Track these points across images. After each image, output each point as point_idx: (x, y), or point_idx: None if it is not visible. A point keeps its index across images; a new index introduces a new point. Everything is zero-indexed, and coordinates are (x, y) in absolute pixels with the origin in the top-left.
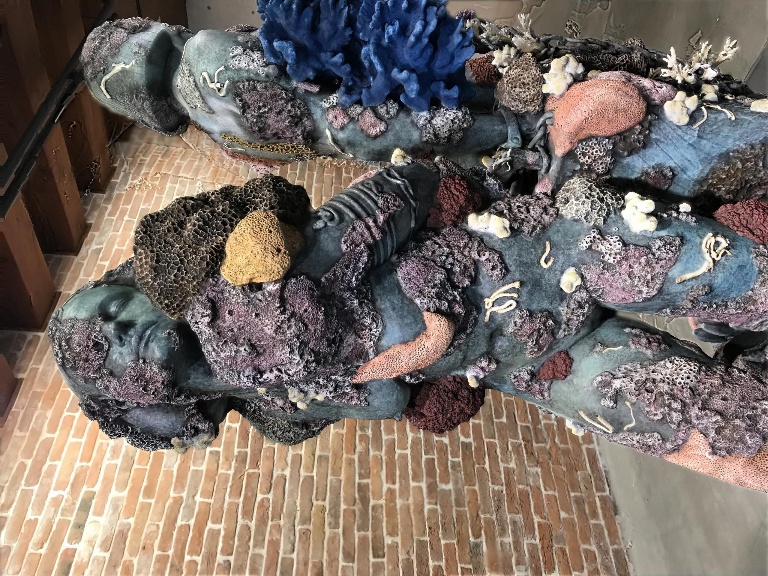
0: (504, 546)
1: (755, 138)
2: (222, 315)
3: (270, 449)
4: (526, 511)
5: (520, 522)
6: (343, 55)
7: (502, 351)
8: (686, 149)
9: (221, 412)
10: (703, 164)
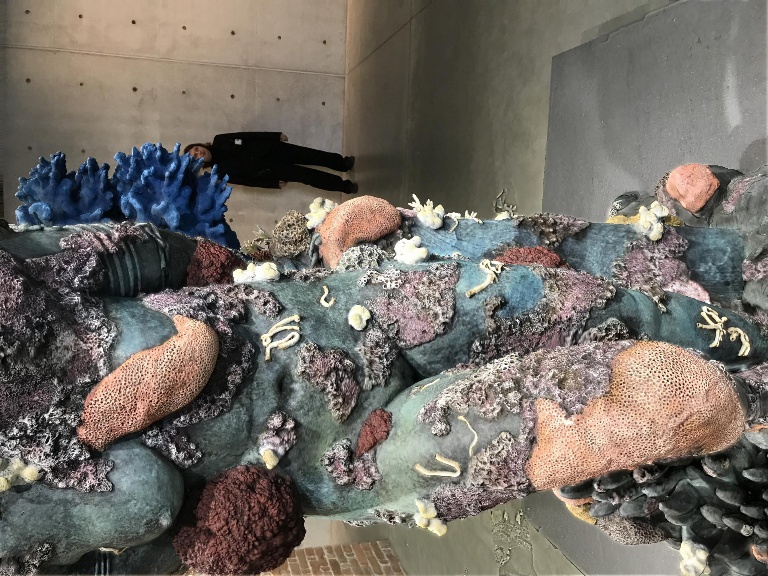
0: None
1: (508, 238)
2: None
3: None
4: None
5: None
6: (102, 209)
7: (298, 405)
8: (452, 251)
9: None
10: None
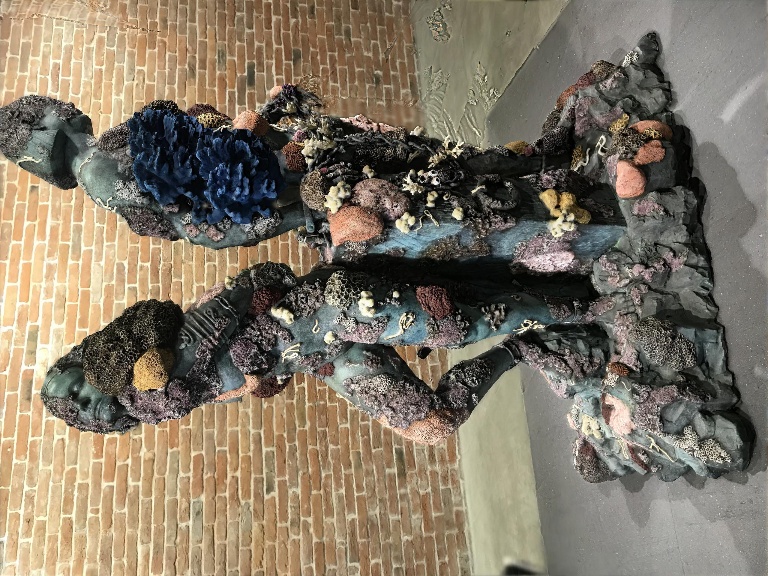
0: None
1: (452, 233)
2: (136, 400)
3: (178, 283)
4: None
5: None
6: (192, 193)
7: (294, 370)
8: (411, 240)
9: None
10: (423, 245)
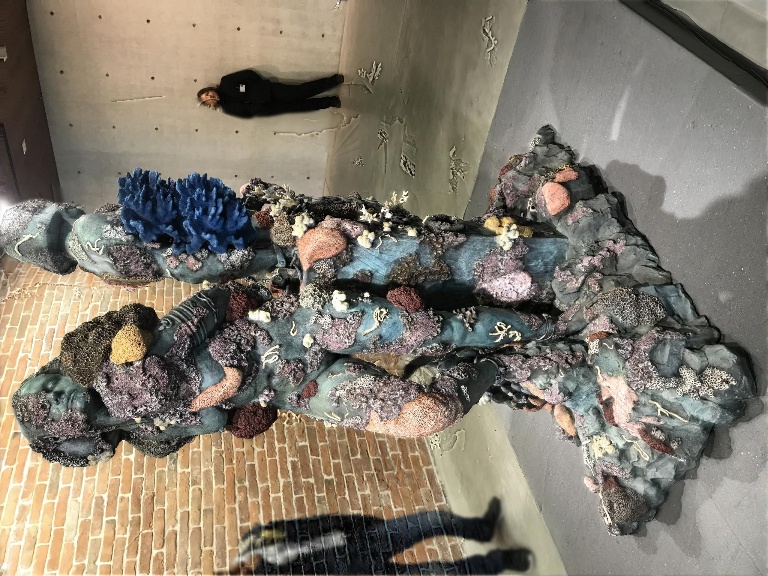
0: (364, 558)
1: (411, 250)
2: (112, 381)
3: (160, 511)
4: (381, 527)
5: (376, 536)
6: (172, 226)
7: (276, 384)
8: (375, 260)
9: (116, 440)
10: (387, 267)
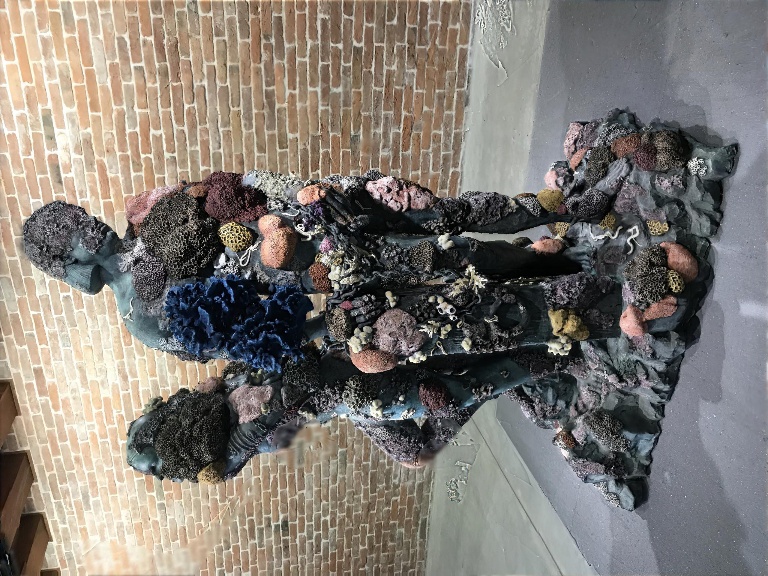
0: (376, 135)
1: None
2: None
3: (186, 62)
4: (397, 108)
5: (391, 117)
6: None
7: None
8: None
9: None
10: None
